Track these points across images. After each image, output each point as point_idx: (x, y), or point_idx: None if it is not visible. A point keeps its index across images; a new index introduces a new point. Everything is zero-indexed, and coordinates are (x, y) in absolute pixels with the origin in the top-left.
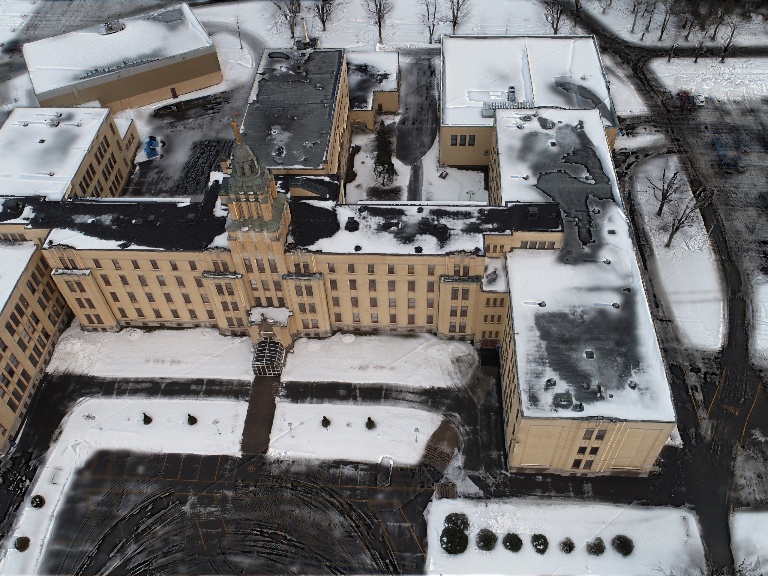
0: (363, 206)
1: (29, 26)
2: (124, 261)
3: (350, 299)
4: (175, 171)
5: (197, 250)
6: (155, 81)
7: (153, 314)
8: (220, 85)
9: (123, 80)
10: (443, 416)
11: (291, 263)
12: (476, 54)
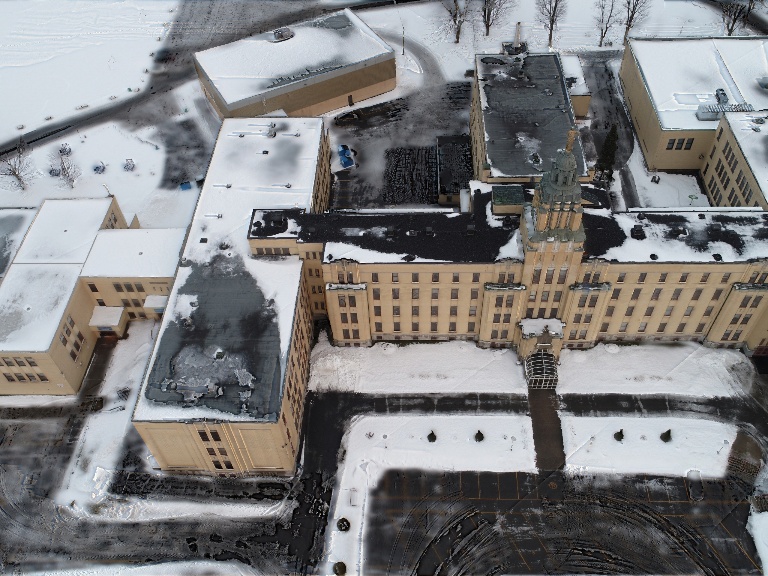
0: (641, 213)
1: (174, 35)
2: (405, 274)
3: (626, 309)
4: (376, 180)
5: (487, 262)
6: (336, 89)
7: (410, 328)
8: (393, 92)
9: (308, 88)
10: (737, 427)
11: (582, 273)
12: (668, 56)
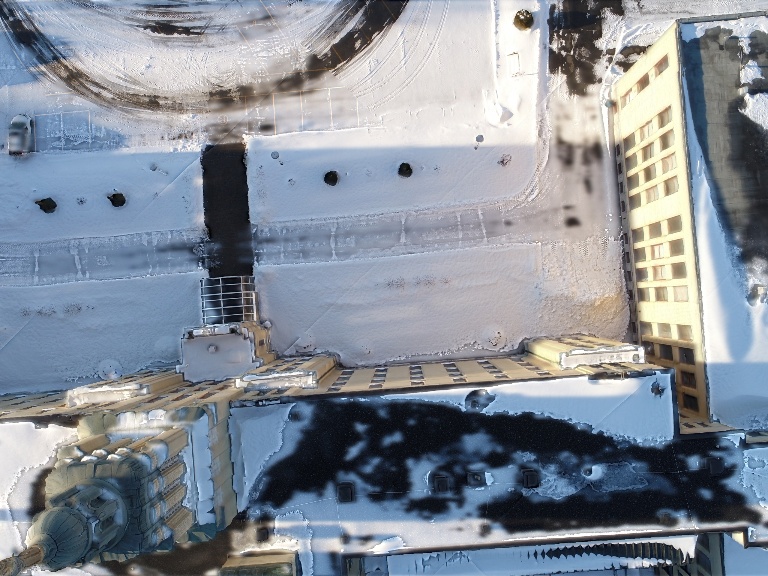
0: None
1: None
2: None
3: None
4: None
5: (310, 401)
6: None
7: None
8: None
9: None
10: None
11: None
12: None
